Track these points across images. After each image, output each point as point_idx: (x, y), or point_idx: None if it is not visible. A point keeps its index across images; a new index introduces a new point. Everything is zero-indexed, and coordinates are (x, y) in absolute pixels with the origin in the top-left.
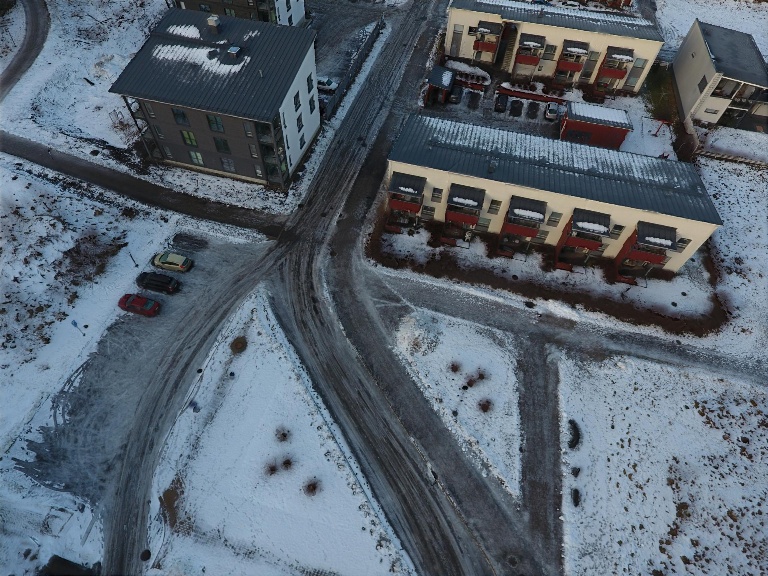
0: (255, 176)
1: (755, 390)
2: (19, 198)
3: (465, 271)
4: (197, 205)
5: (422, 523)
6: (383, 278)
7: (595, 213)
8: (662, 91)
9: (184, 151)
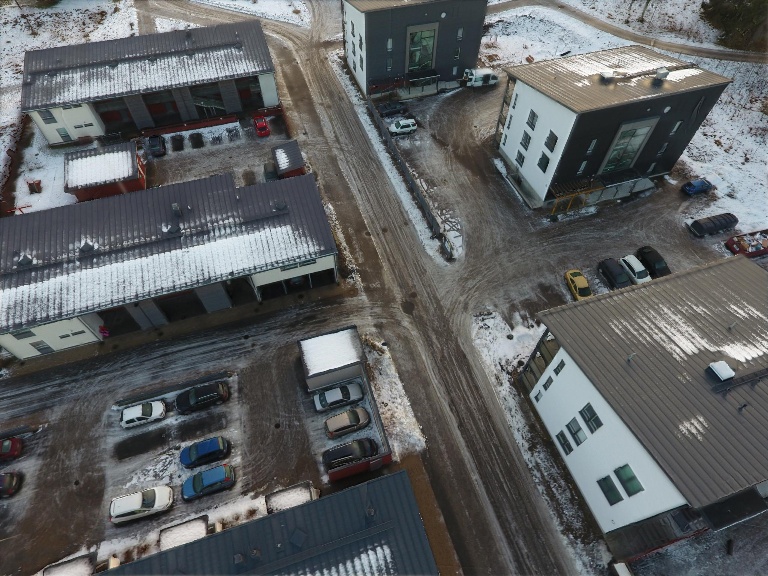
0: None
1: None
2: None
3: None
4: None
5: None
6: None
7: None
8: None
9: None
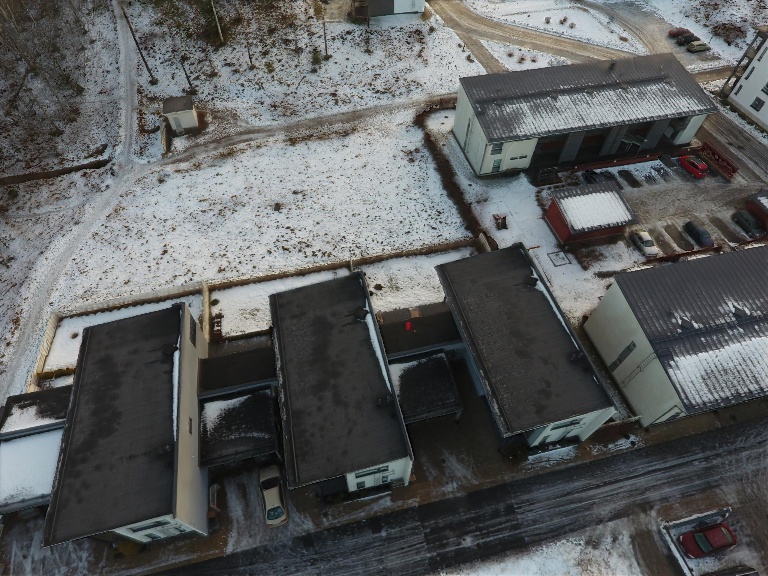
0: None
1: (392, 101)
2: None
3: None
4: None
5: None
6: None
7: None
8: None
9: None
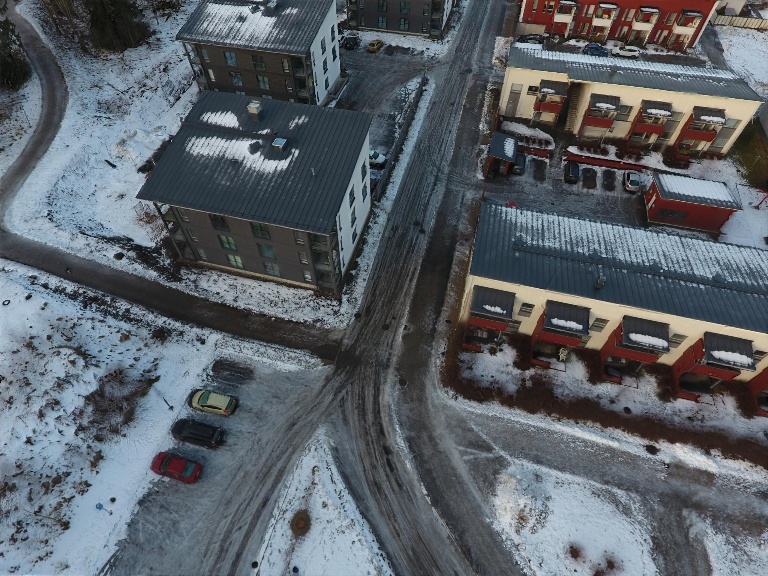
0: (303, 281)
1: None
2: (33, 324)
3: (565, 403)
4: (237, 319)
5: None
6: (467, 416)
7: (732, 338)
8: (757, 153)
9: (221, 254)
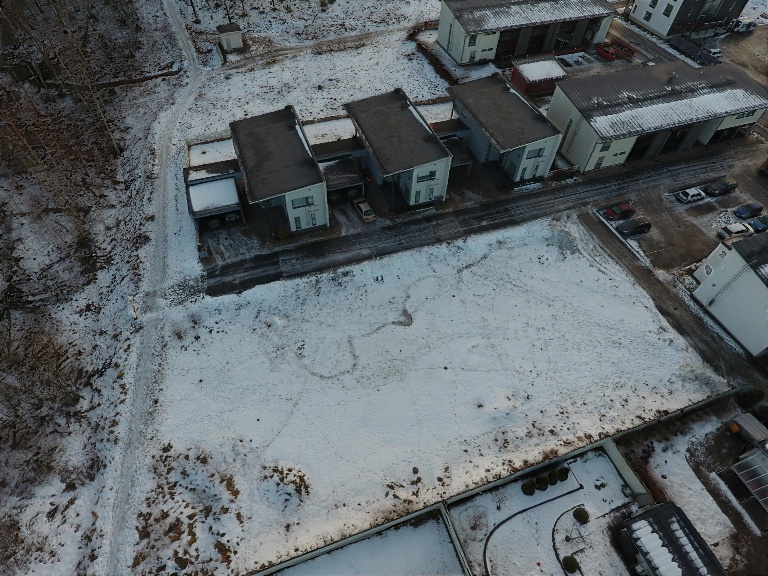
0: None
1: None
2: None
3: None
4: None
5: None
6: None
7: None
8: None
9: None
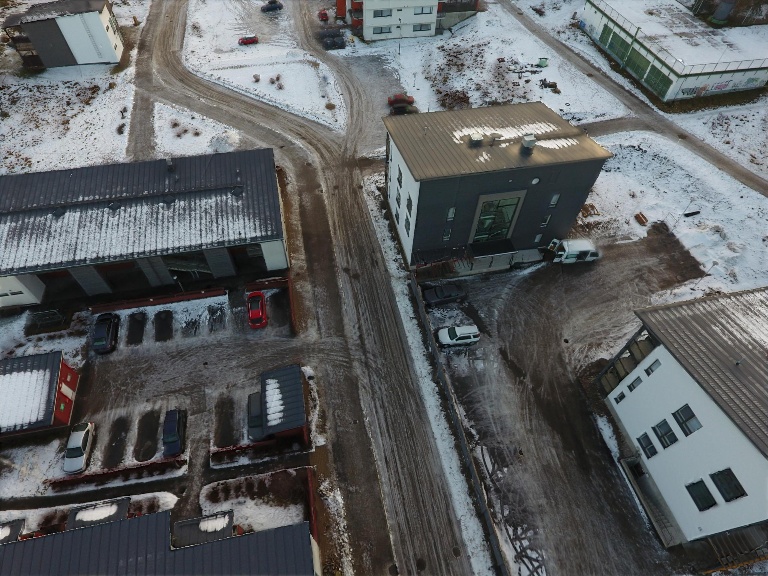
0: None
1: None
2: None
3: None
4: None
5: (203, 87)
6: None
7: None
8: None
9: None
